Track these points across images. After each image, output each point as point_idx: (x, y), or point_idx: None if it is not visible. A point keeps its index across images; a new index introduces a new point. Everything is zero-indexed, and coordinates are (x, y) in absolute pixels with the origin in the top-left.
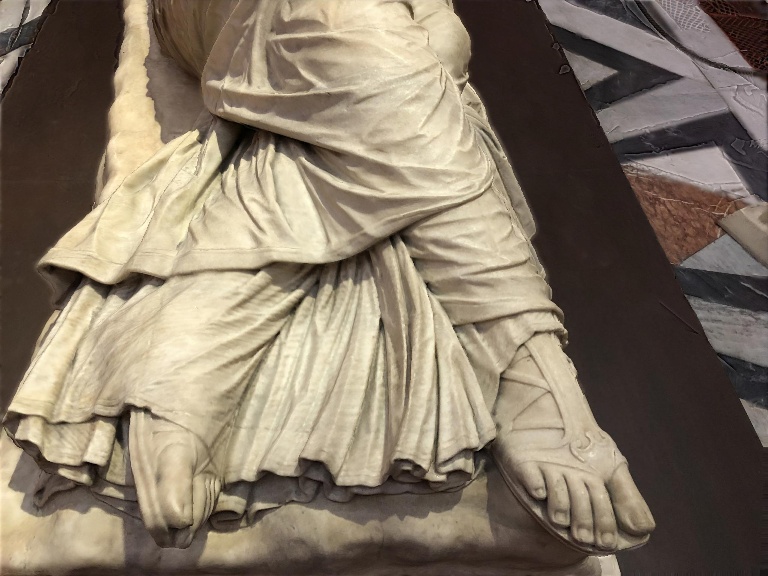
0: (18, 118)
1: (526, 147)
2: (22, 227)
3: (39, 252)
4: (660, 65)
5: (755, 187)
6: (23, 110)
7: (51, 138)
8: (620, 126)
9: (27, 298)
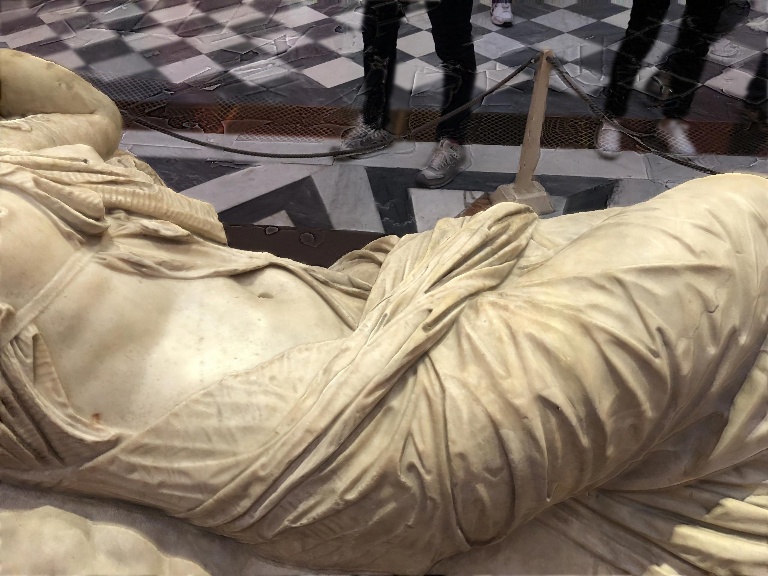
0: None
1: None
2: None
3: None
4: (288, 182)
5: (473, 186)
6: None
7: None
8: None
9: None
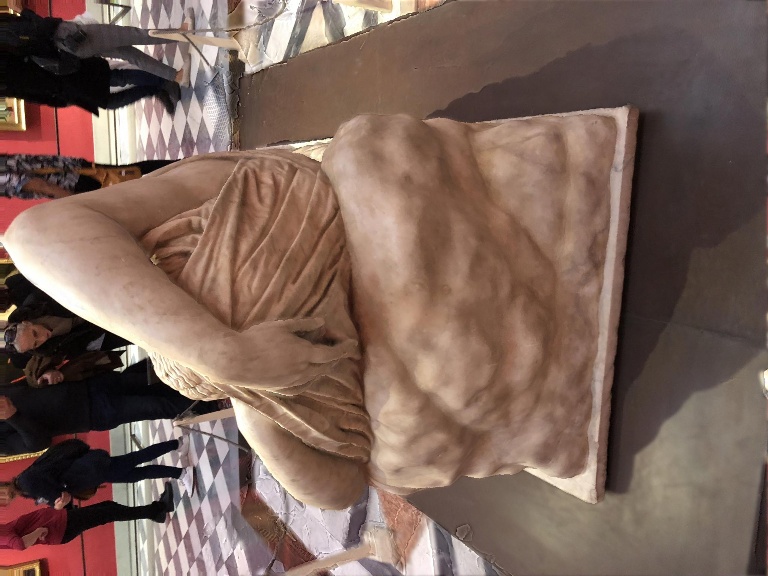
0: (421, 36)
1: None
2: (357, 89)
3: (347, 106)
4: None
5: None
6: (429, 34)
7: (406, 73)
8: (453, 548)
9: (331, 112)
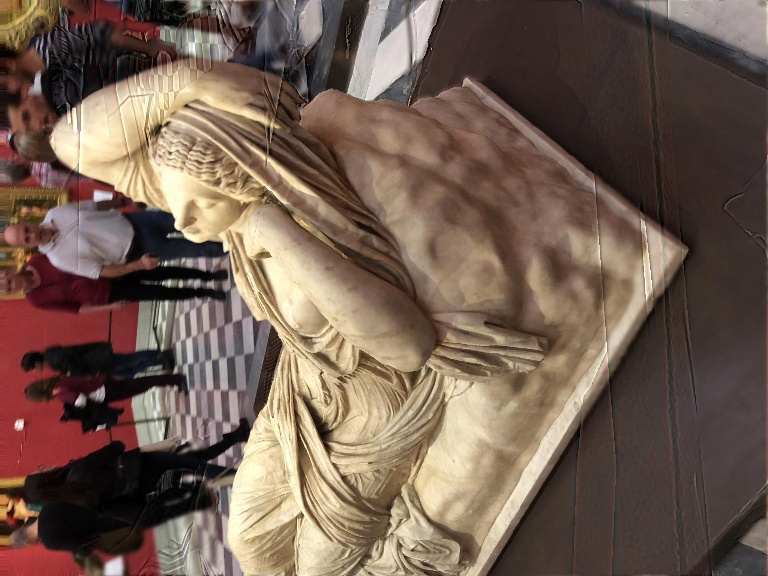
0: None
1: (554, 566)
2: None
3: None
4: None
5: None
6: None
7: None
8: None
9: None
